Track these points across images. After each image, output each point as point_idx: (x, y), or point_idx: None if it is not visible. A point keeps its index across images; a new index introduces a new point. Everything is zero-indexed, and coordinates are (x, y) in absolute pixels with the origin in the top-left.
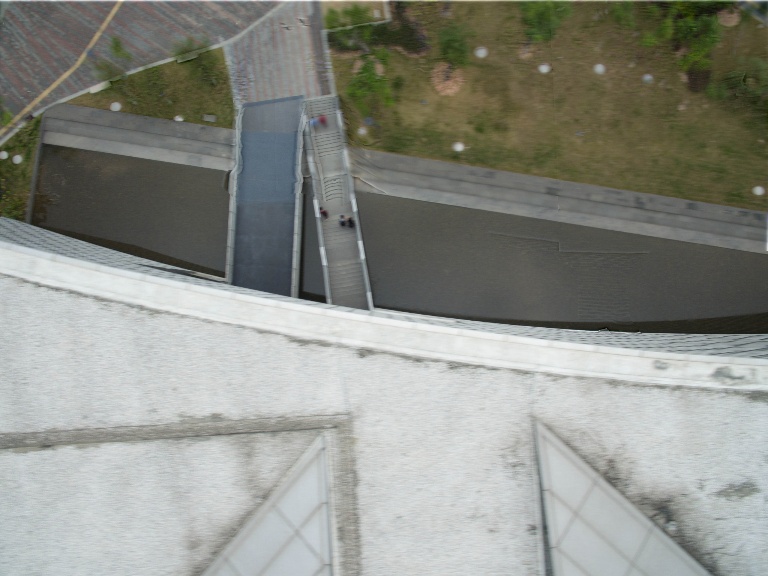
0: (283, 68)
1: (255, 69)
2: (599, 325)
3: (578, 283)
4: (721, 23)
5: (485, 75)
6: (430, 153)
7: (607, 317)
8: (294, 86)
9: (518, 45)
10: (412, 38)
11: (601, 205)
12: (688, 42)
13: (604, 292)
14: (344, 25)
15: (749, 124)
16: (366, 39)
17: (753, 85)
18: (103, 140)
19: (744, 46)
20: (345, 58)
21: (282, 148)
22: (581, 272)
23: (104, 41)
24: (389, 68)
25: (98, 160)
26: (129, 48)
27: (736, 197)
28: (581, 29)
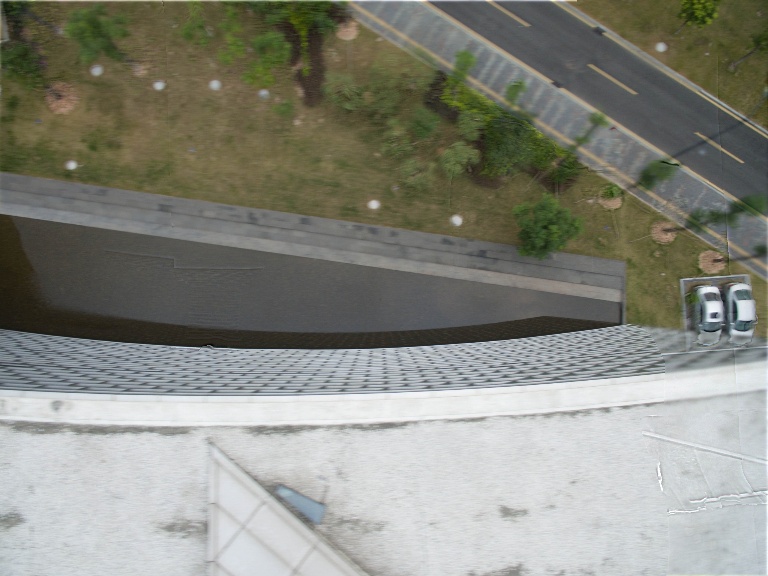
0: None
1: None
2: (205, 342)
3: (191, 299)
4: (340, 37)
5: (100, 93)
6: (43, 172)
7: (216, 333)
8: None
9: (134, 63)
10: (27, 57)
11: (214, 221)
12: (301, 57)
13: (217, 308)
14: None
15: (365, 138)
16: None
17: (370, 98)
18: None
19: (363, 59)
20: None
21: None
22: (196, 288)
23: None
24: (5, 88)
25: None
26: None
27: (350, 211)
28: (194, 46)
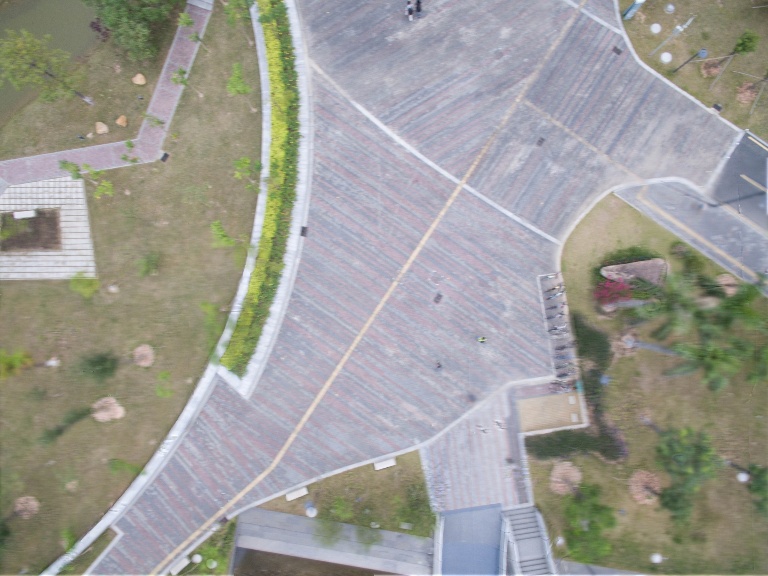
0: (480, 474)
1: (452, 474)
2: None
3: None
4: None
5: (683, 483)
6: (628, 564)
7: None
8: (491, 493)
9: (716, 452)
10: (610, 445)
11: None
12: None
13: None
14: (541, 428)
15: None
16: (565, 447)
17: None
18: (298, 545)
19: None
20: (542, 464)
21: (482, 563)
22: None
23: (299, 443)
24: (586, 475)
25: (292, 564)
26: (324, 450)
27: None
28: None
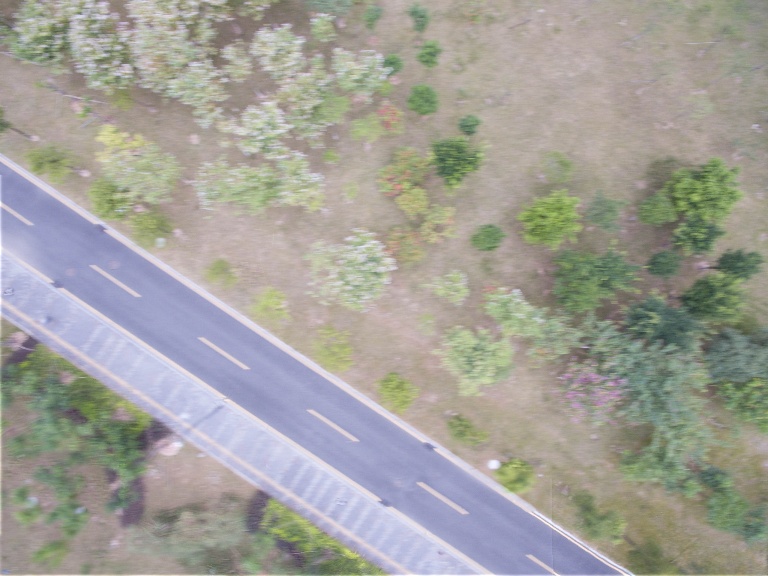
0: None
1: None
2: None
3: None
4: (160, 452)
5: None
6: None
7: None
8: None
9: None
10: None
11: None
12: (117, 478)
13: None
14: None
15: (183, 560)
16: None
17: (190, 519)
18: None
19: (184, 476)
20: None
21: None
22: None
23: None
24: None
25: None
26: None
27: None
28: (8, 464)
